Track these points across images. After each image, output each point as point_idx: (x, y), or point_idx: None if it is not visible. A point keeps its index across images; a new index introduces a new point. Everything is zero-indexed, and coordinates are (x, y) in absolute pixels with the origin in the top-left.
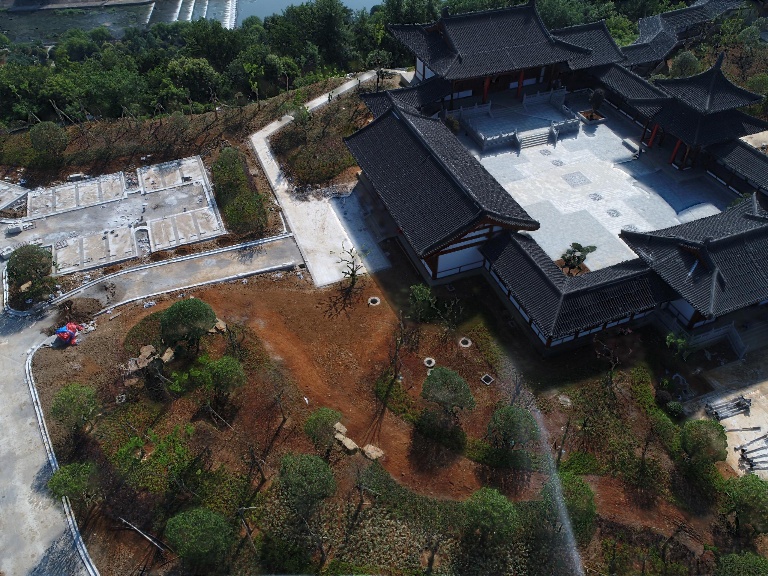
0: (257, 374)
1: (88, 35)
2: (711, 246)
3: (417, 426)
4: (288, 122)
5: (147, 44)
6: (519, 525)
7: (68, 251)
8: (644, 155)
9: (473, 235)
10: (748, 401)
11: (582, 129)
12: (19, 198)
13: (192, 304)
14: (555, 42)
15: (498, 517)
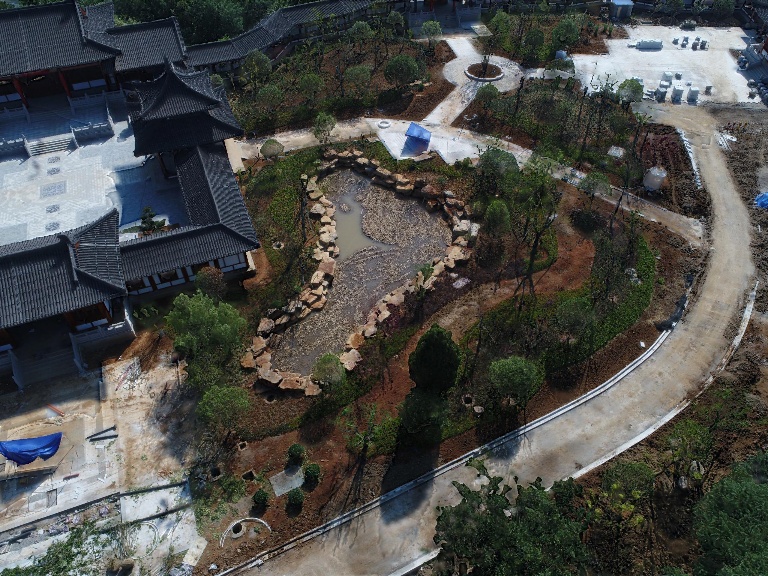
0: None
1: None
2: None
3: None
4: None
5: None
6: None
7: None
8: (148, 162)
9: None
10: None
11: (119, 134)
12: None
13: None
14: (88, 41)
15: None
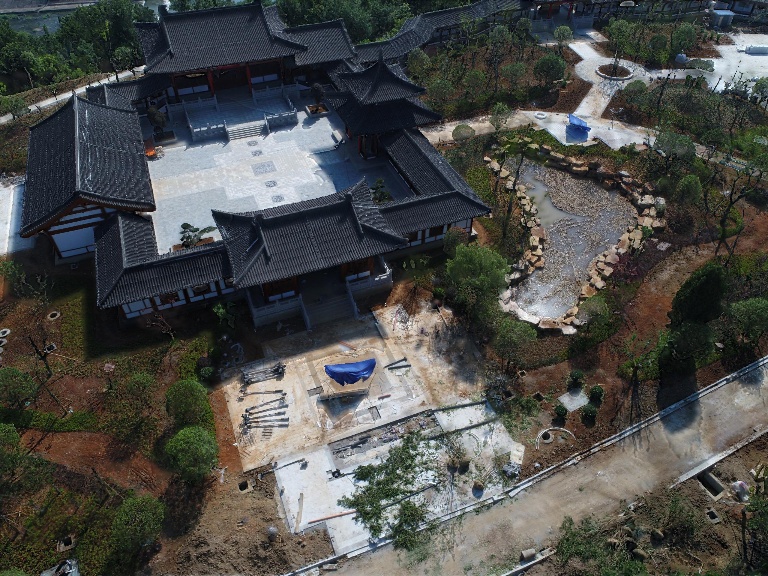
0: None
1: None
2: (268, 223)
3: None
4: None
5: None
6: None
7: None
8: (342, 146)
9: (84, 215)
10: (282, 367)
11: (302, 122)
12: None
13: None
14: (275, 39)
15: None
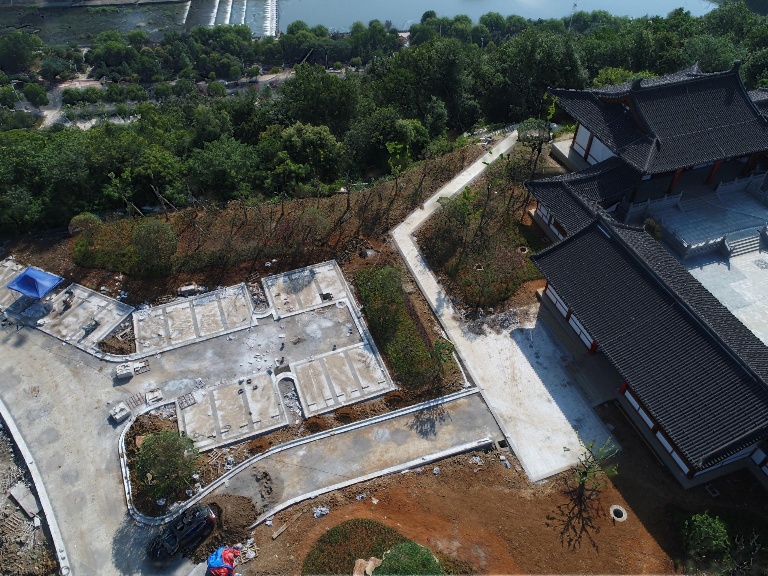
0: None
1: (125, 38)
2: None
3: None
4: (433, 211)
5: (188, 49)
6: None
7: (197, 412)
8: None
9: None
10: None
11: None
12: (122, 321)
13: (422, 569)
14: (766, 121)
15: None
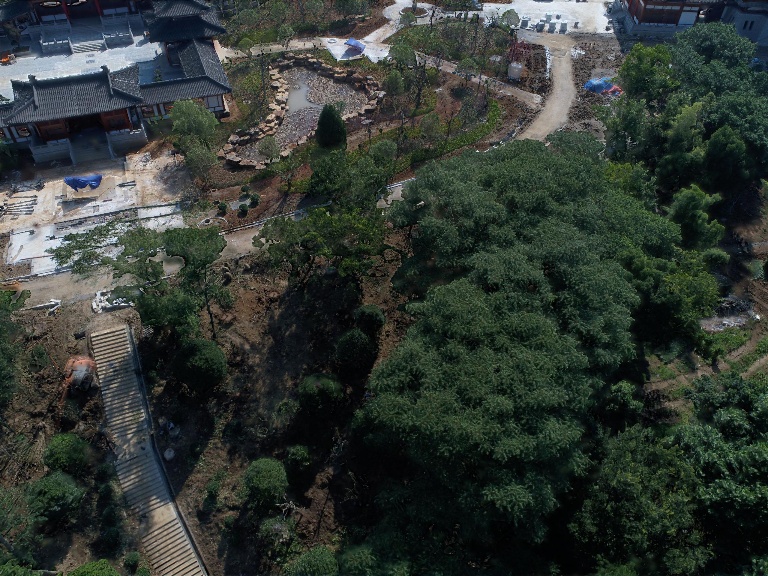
0: None
1: None
2: (41, 84)
3: None
4: None
5: None
6: None
7: None
8: (158, 57)
9: None
10: (41, 182)
11: (137, 42)
12: None
13: None
14: None
15: None
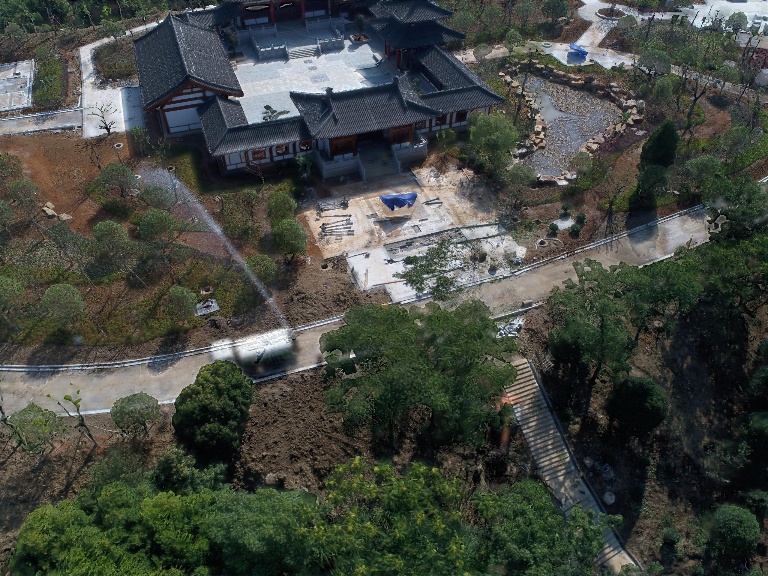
0: (8, 179)
1: None
2: (336, 97)
3: (104, 206)
4: (114, 39)
5: None
6: (141, 252)
7: None
8: (382, 63)
9: (190, 97)
10: (346, 200)
11: (348, 47)
12: None
13: None
14: None
15: (105, 230)
